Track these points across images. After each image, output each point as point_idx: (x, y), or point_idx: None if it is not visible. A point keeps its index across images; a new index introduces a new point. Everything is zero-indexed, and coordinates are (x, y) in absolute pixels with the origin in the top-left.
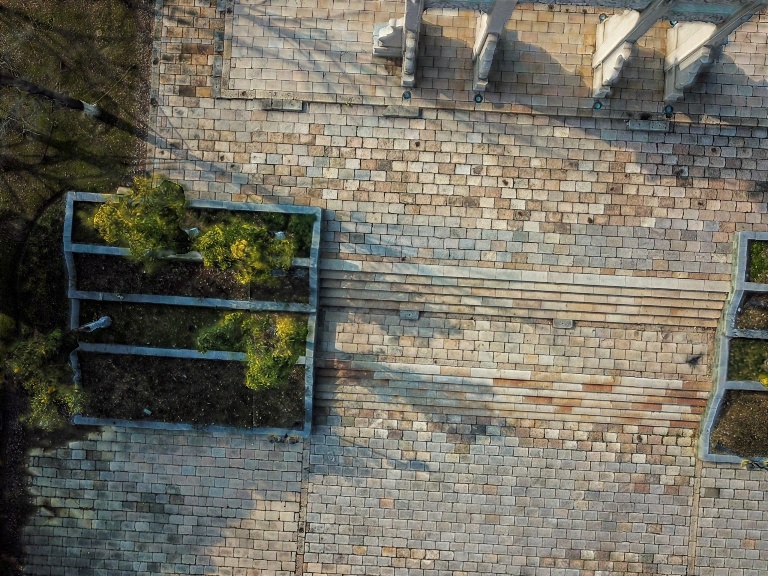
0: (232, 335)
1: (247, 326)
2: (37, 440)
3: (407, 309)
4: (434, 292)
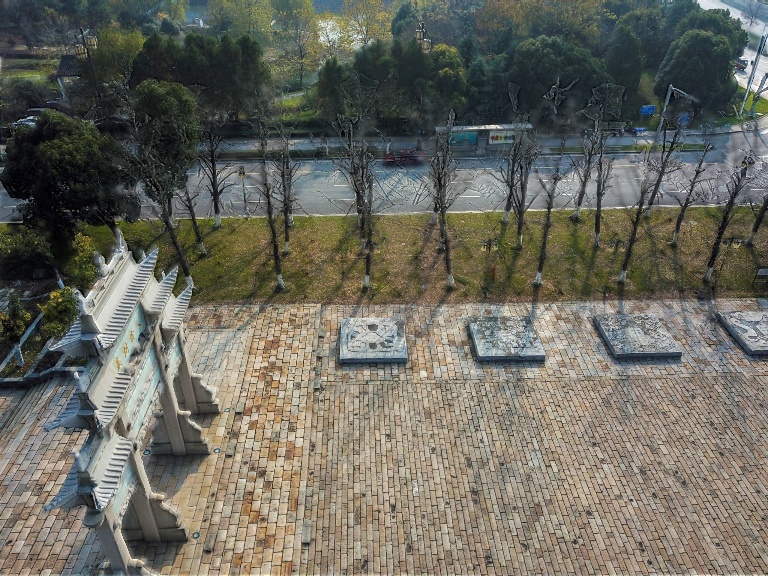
0: (13, 311)
1: (19, 323)
2: (19, 290)
3: (1, 433)
4: (4, 443)
